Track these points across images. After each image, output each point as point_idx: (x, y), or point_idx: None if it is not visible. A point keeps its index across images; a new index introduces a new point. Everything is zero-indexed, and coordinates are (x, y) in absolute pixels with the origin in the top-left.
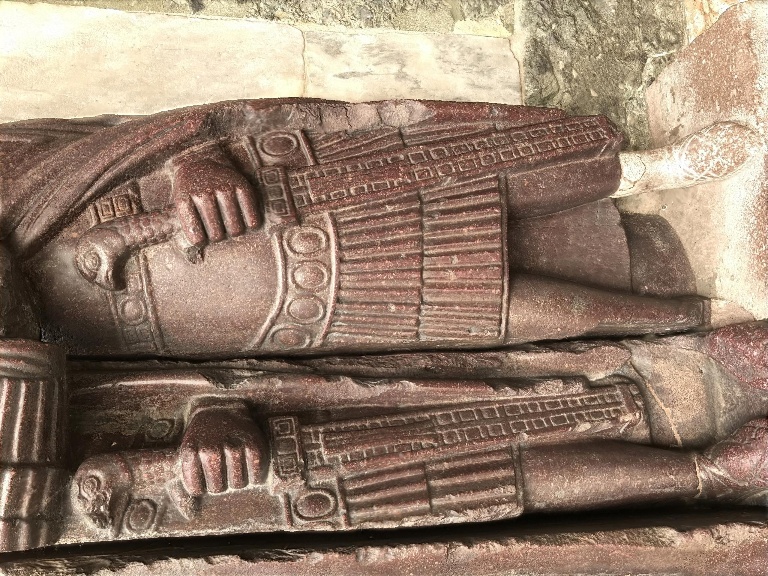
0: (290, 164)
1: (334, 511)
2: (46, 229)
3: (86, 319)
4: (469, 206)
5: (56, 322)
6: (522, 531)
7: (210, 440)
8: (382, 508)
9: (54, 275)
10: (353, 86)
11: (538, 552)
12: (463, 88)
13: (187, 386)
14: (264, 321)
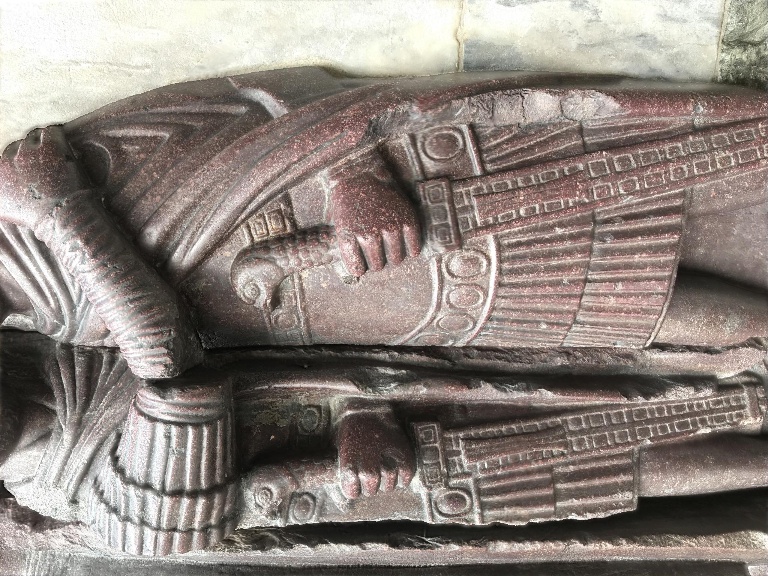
0: (454, 171)
1: (470, 510)
2: (202, 256)
3: (240, 326)
4: (646, 228)
5: (212, 329)
6: (630, 525)
7: (368, 462)
8: (512, 509)
9: (210, 292)
10: (519, 17)
11: (643, 550)
12: (652, 21)
13: (338, 390)
14: (412, 330)
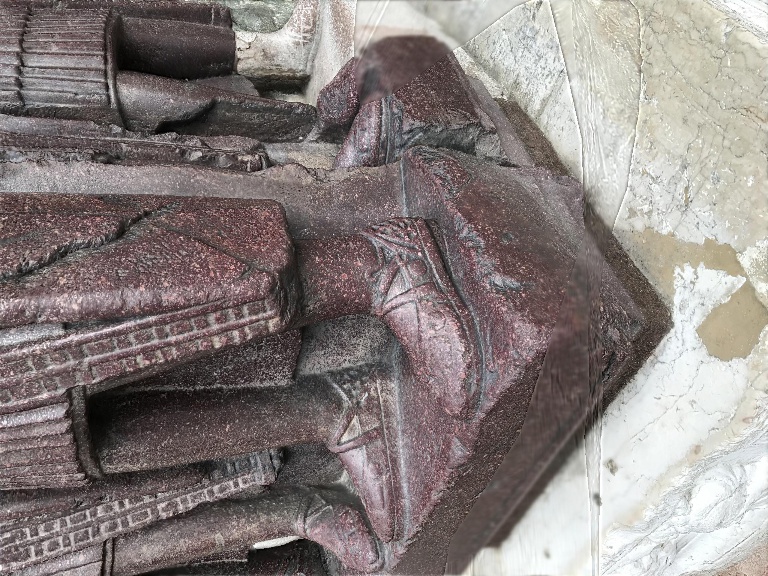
0: None
1: None
2: None
3: None
4: None
5: None
6: None
7: None
8: None
9: None
10: None
11: (103, 171)
12: None
13: None
14: None
